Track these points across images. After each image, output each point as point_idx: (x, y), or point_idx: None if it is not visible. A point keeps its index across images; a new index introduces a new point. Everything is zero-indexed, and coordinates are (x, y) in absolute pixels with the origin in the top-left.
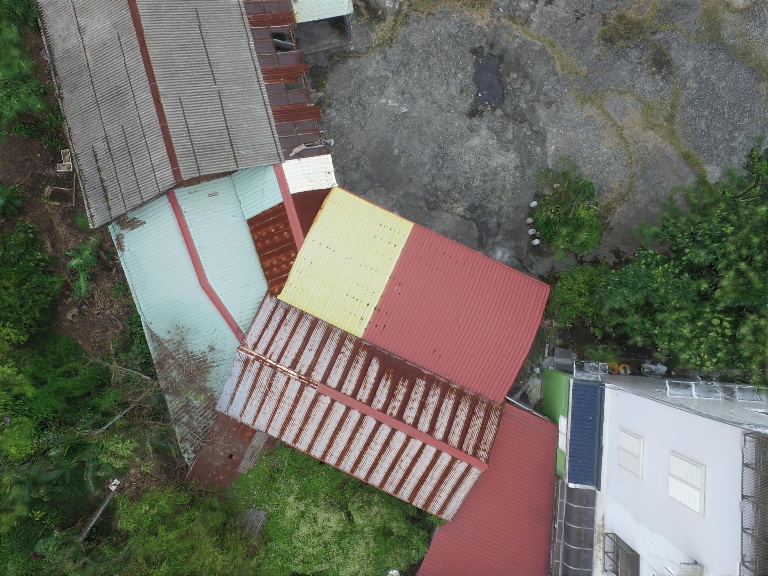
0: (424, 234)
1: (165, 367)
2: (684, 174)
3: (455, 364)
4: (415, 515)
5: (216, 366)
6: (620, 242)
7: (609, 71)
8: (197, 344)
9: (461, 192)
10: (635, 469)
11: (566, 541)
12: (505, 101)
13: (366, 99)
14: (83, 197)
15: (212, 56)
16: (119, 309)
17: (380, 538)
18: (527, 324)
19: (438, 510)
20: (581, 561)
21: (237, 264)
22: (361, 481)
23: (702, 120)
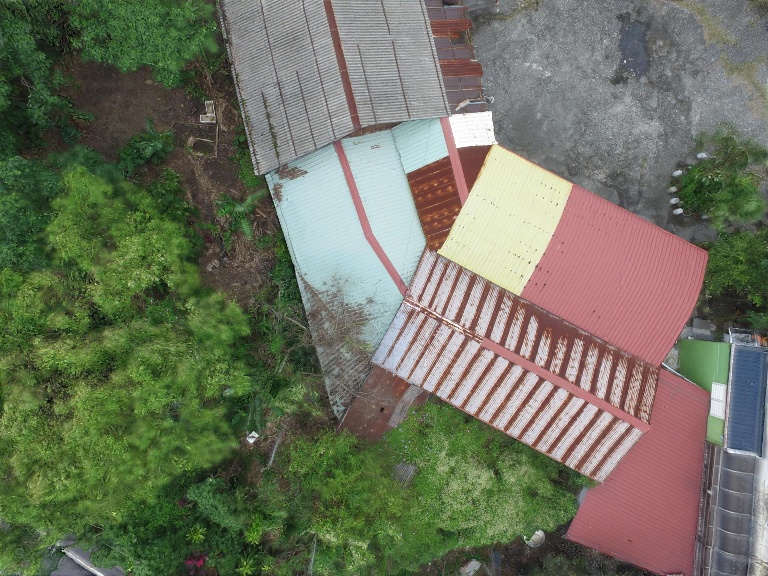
0: (584, 195)
1: (317, 319)
2: None
3: (614, 325)
4: (556, 478)
5: (372, 319)
6: (762, 215)
7: (757, 42)
8: (354, 296)
9: (603, 159)
10: None
11: (722, 506)
12: (650, 69)
13: (510, 62)
14: (249, 143)
15: (386, 6)
16: (258, 263)
17: (527, 498)
18: (689, 288)
19: (591, 471)
20: (739, 526)
21: (397, 217)
22: (505, 441)
23: None
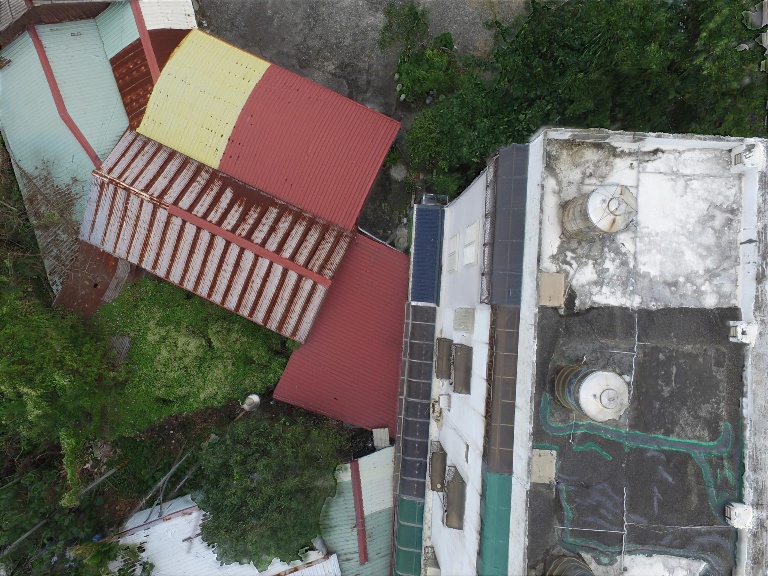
0: (280, 73)
1: (34, 203)
2: None
3: (306, 193)
4: (279, 349)
5: (79, 198)
6: None
7: None
8: (61, 177)
9: (332, 51)
10: (453, 265)
11: (410, 357)
12: None
13: None
14: None
15: None
16: (1, 163)
17: (240, 364)
18: (374, 153)
19: (291, 332)
20: (421, 373)
21: (98, 100)
22: (226, 315)
23: None
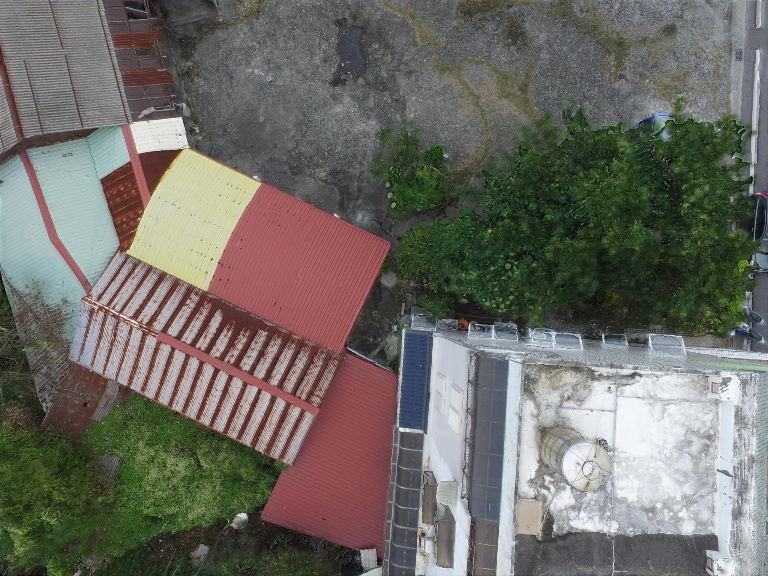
0: (270, 193)
1: (24, 320)
2: (537, 141)
3: (295, 316)
4: (268, 463)
5: (69, 318)
6: (476, 206)
7: (467, 42)
8: (52, 297)
9: (324, 158)
10: (440, 407)
11: (397, 482)
12: (367, 71)
13: (233, 69)
14: None
15: (60, 22)
16: None
17: (228, 482)
18: (363, 278)
19: (279, 454)
20: (409, 500)
21: (89, 221)
22: None
23: (555, 89)
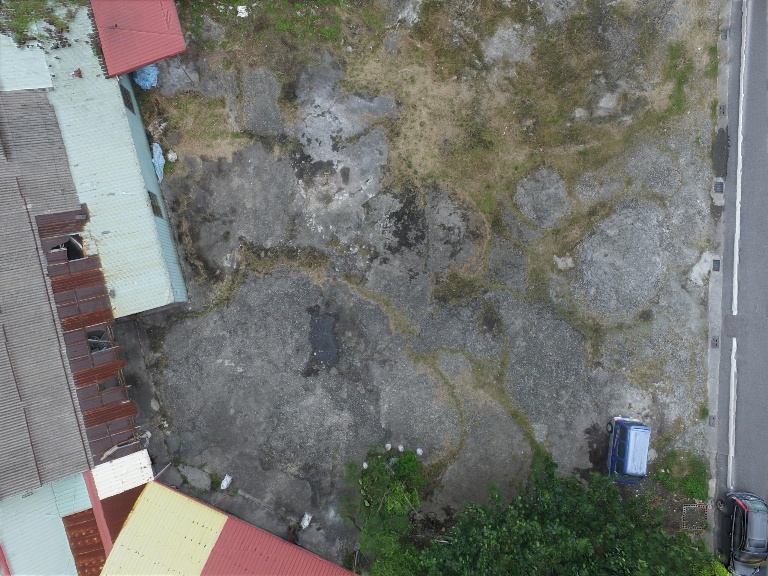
0: (237, 528)
1: None
2: (513, 432)
3: None
4: None
5: None
6: (451, 499)
7: (441, 330)
8: None
9: (296, 451)
10: None
11: None
12: (340, 360)
13: (203, 359)
14: None
15: (19, 371)
16: None
17: None
18: None
19: None
20: None
21: (49, 565)
22: None
23: (531, 378)
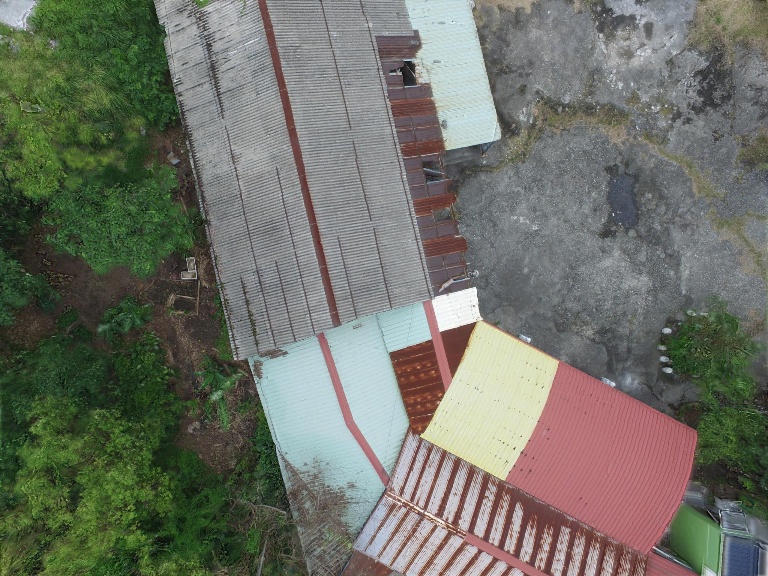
0: (570, 373)
1: (298, 498)
2: None
3: (601, 512)
4: None
5: (354, 503)
6: (753, 372)
7: (747, 195)
8: (335, 479)
9: (591, 314)
10: None
11: None
12: (639, 222)
13: (497, 215)
14: (227, 327)
15: (367, 191)
16: (240, 423)
17: None
18: (677, 475)
19: None
20: None
21: (380, 399)
22: None
23: None
